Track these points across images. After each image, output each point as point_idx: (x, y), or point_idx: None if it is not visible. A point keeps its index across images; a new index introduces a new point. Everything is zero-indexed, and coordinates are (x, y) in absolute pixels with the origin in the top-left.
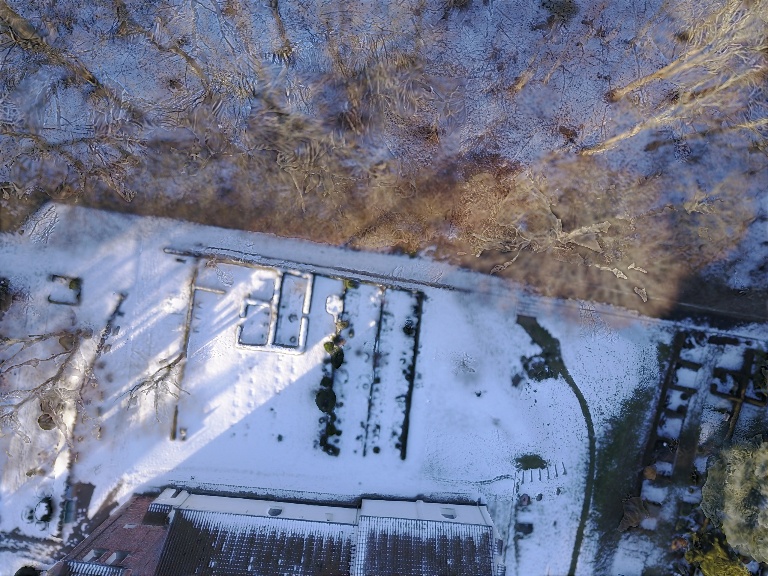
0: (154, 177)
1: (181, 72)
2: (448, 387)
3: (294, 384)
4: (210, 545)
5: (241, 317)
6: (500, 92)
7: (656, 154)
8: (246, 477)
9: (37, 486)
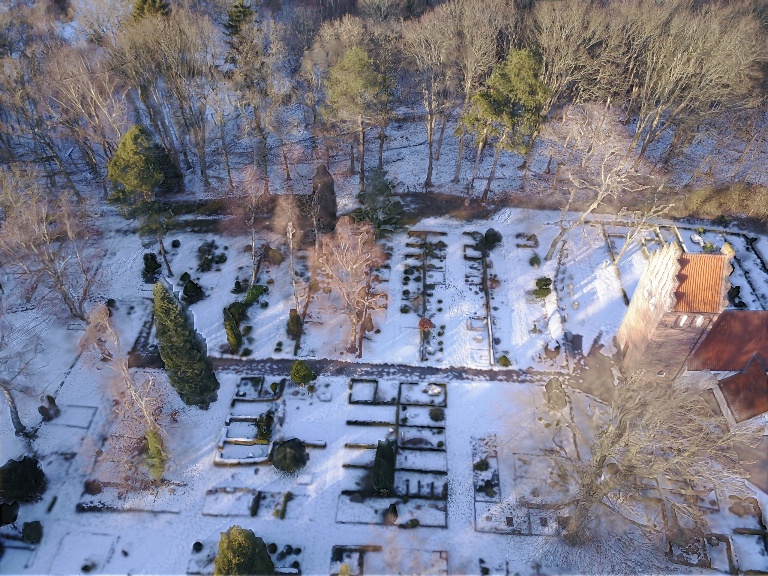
0: (563, 194)
1: (561, 161)
2: None
3: None
4: None
5: (643, 245)
6: (731, 163)
7: None
8: None
9: (538, 340)
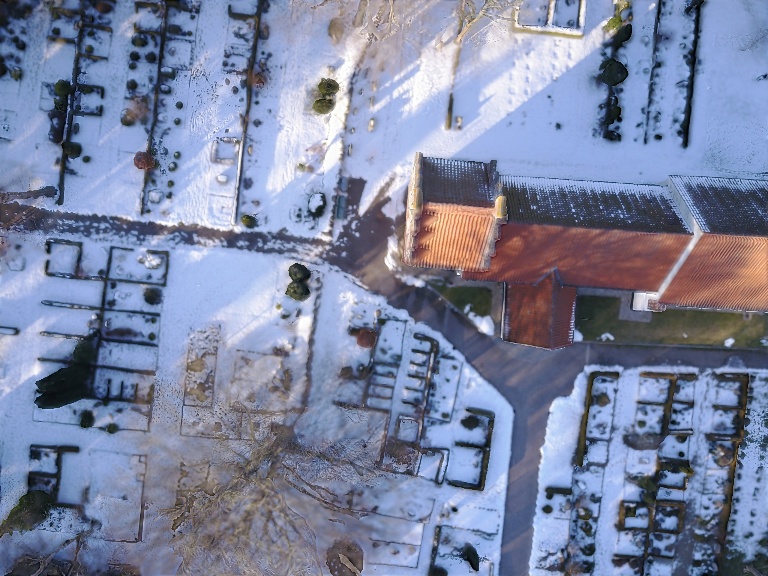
0: None
1: None
2: (729, 74)
3: (571, 71)
4: (524, 196)
5: None
6: None
7: None
8: (523, 167)
9: (305, 183)
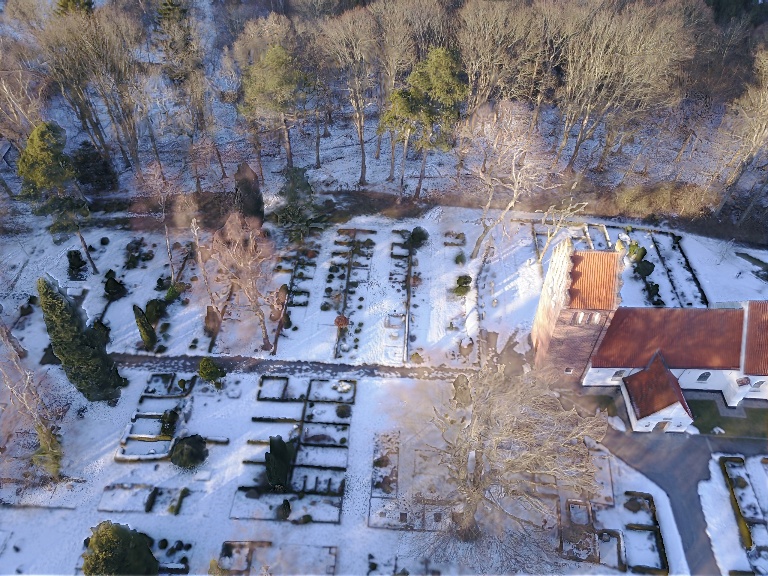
0: (497, 193)
1: None
2: (716, 275)
3: None
4: None
5: None
6: (669, 162)
7: (766, 185)
8: None
9: (454, 337)
